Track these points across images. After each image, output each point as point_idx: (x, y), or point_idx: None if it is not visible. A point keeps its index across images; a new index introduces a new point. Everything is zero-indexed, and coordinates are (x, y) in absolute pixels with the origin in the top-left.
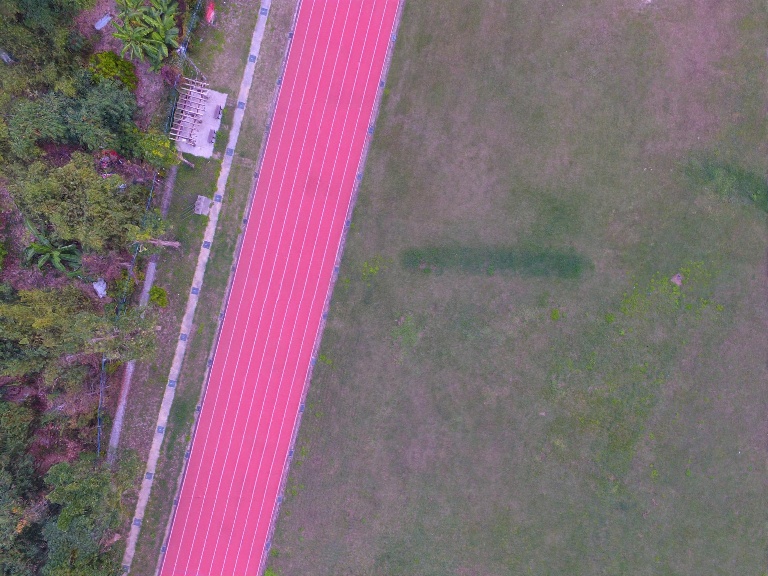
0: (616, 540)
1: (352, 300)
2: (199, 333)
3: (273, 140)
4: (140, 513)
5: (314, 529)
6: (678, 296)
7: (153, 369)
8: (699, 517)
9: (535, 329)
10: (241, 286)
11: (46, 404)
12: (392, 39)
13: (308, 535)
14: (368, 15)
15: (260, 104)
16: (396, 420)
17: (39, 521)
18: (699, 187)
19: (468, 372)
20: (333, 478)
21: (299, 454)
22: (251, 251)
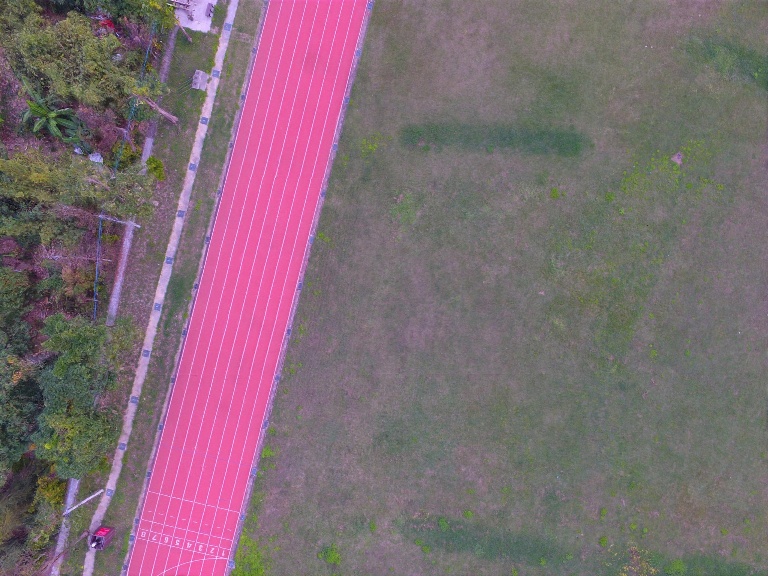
0: (615, 420)
1: (351, 177)
2: (196, 209)
3: (271, 15)
4: (137, 391)
5: (312, 408)
6: (678, 175)
7: (150, 245)
8: (698, 397)
9: (534, 208)
10: (239, 163)
11: (42, 278)
12: None
13: (306, 414)
14: None
15: None
16: (395, 298)
17: (35, 377)
18: (700, 65)
19: (467, 251)
20: (331, 356)
21: (297, 332)
22: (249, 127)
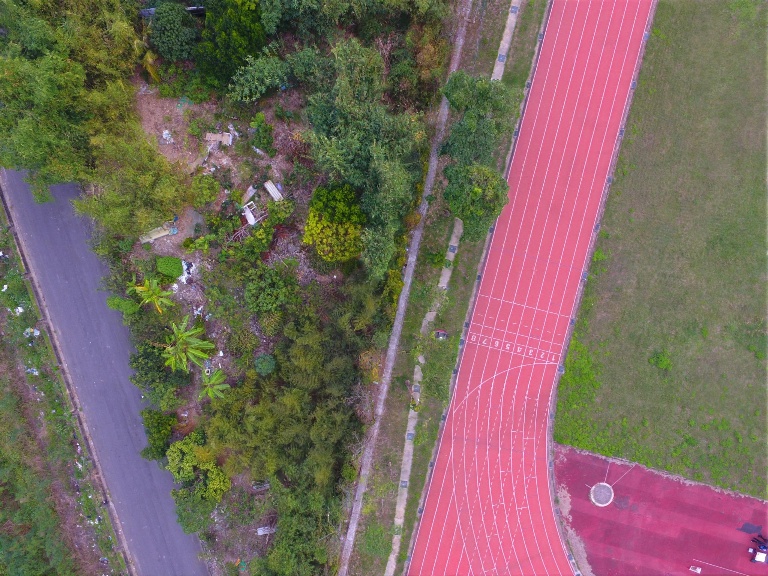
0: None
1: None
2: (531, 4)
3: None
4: None
5: (645, 210)
6: None
7: (483, 42)
8: None
9: None
10: None
11: None
12: None
13: (639, 216)
14: None
15: None
16: (732, 97)
17: (423, 144)
18: None
19: None
20: (666, 157)
21: (631, 132)
22: None
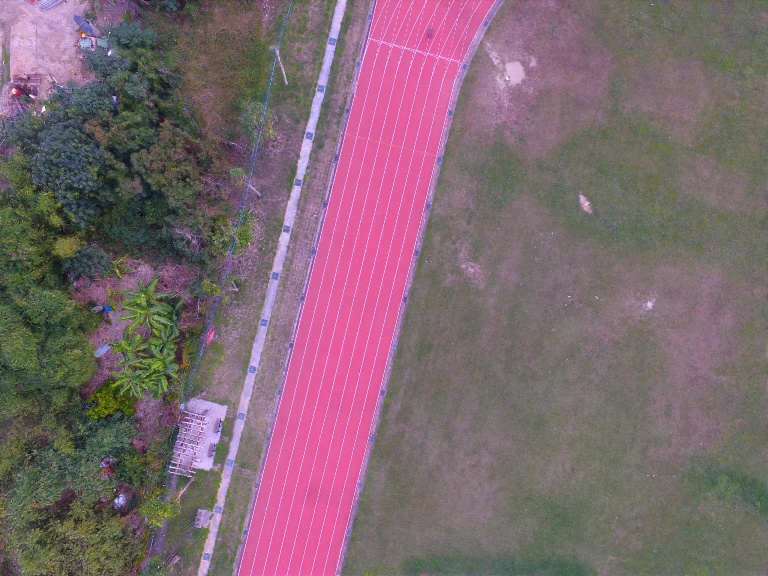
0: None
1: None
2: None
3: (273, 450)
4: None
5: None
6: None
7: None
8: None
9: None
10: None
11: None
12: (393, 348)
13: None
14: (368, 324)
15: (260, 415)
16: None
17: None
18: (702, 493)
19: None
20: None
21: None
22: (251, 562)
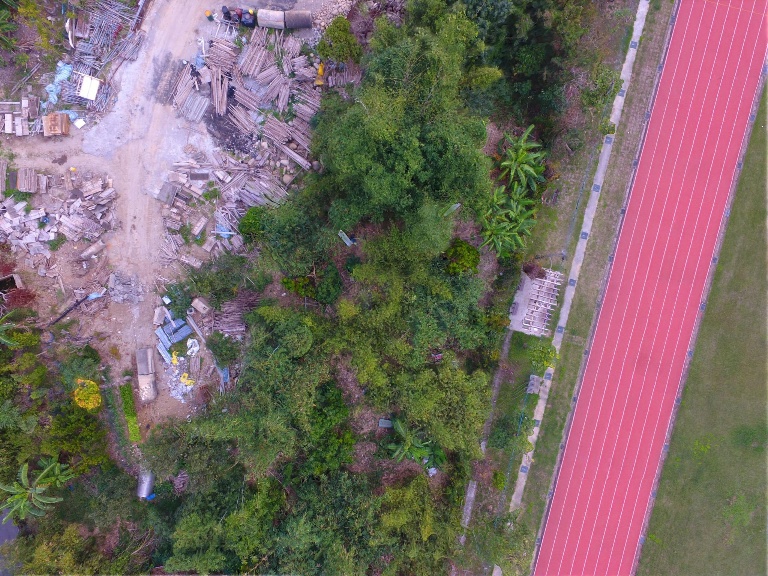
0: None
1: (682, 478)
2: (529, 512)
3: (604, 317)
4: None
5: None
6: None
7: None
8: None
9: None
10: (570, 464)
11: None
12: (726, 214)
13: None
14: (702, 191)
15: (591, 281)
16: None
17: None
18: None
19: None
20: None
21: None
22: (581, 429)
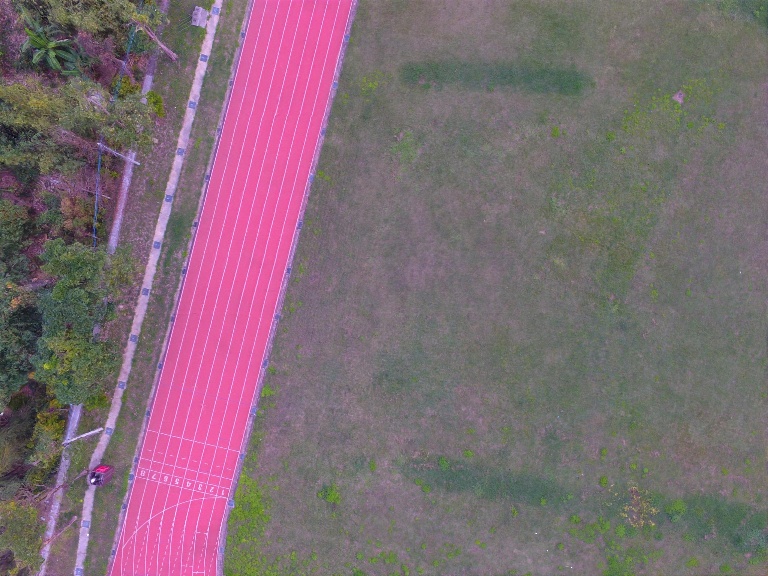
0: (616, 360)
1: (351, 116)
2: (196, 147)
3: None
4: (136, 329)
5: (312, 347)
6: (679, 114)
7: (150, 183)
8: (699, 337)
9: (535, 146)
10: (239, 100)
11: None
12: None
13: (306, 353)
14: None
15: None
16: (395, 237)
17: (34, 304)
18: (701, 3)
19: (467, 189)
20: (331, 295)
21: (297, 271)
22: (249, 65)
